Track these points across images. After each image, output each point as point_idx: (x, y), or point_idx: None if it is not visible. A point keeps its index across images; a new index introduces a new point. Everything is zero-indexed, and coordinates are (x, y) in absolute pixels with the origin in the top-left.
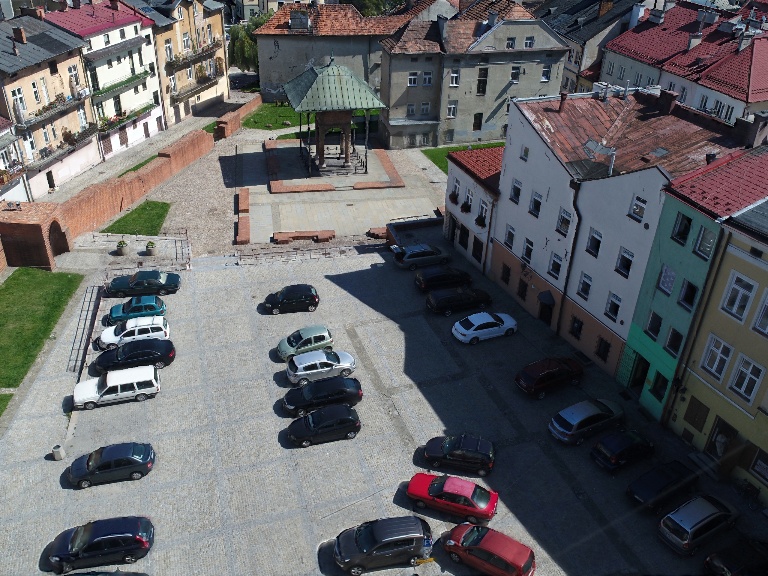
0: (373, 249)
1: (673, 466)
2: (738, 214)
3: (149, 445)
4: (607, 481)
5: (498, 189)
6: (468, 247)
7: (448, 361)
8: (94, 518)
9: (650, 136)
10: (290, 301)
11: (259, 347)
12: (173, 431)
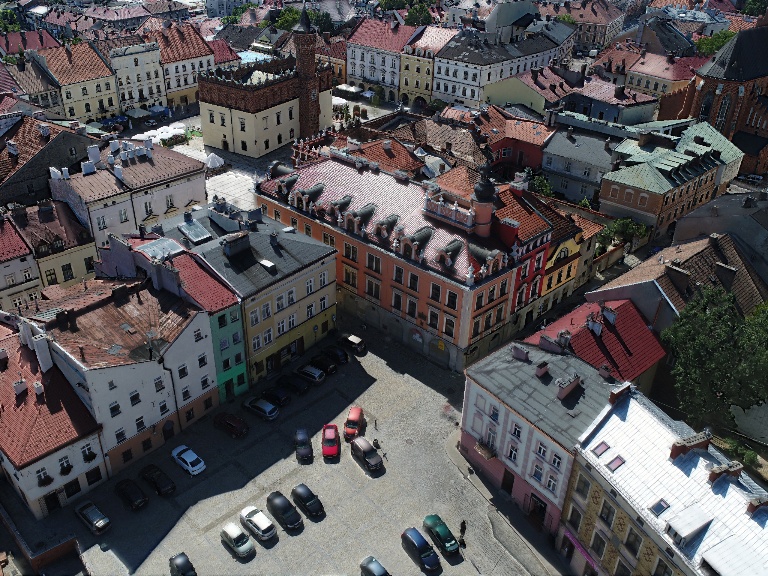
0: (55, 574)
1: (283, 380)
2: (242, 295)
3: (363, 562)
4: (294, 402)
5: (99, 424)
6: (82, 487)
7: (224, 472)
8: (409, 569)
9: (103, 329)
10: (193, 567)
11: (243, 572)
12: (339, 573)
